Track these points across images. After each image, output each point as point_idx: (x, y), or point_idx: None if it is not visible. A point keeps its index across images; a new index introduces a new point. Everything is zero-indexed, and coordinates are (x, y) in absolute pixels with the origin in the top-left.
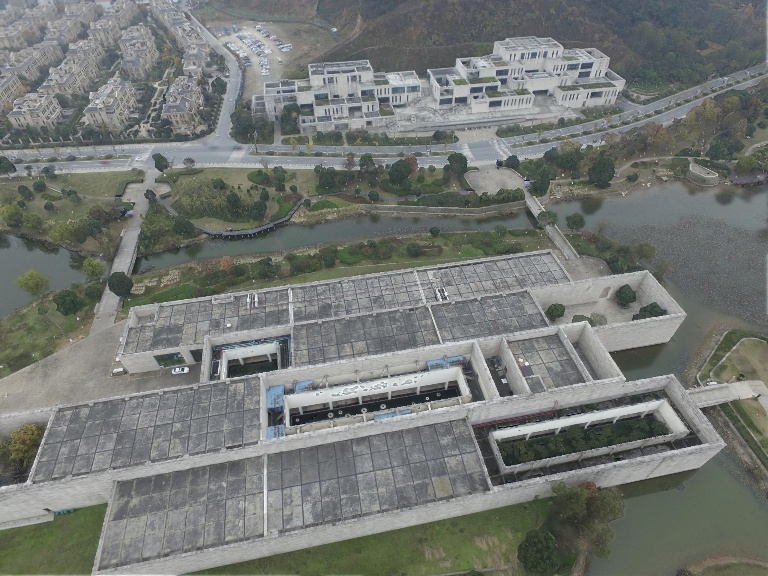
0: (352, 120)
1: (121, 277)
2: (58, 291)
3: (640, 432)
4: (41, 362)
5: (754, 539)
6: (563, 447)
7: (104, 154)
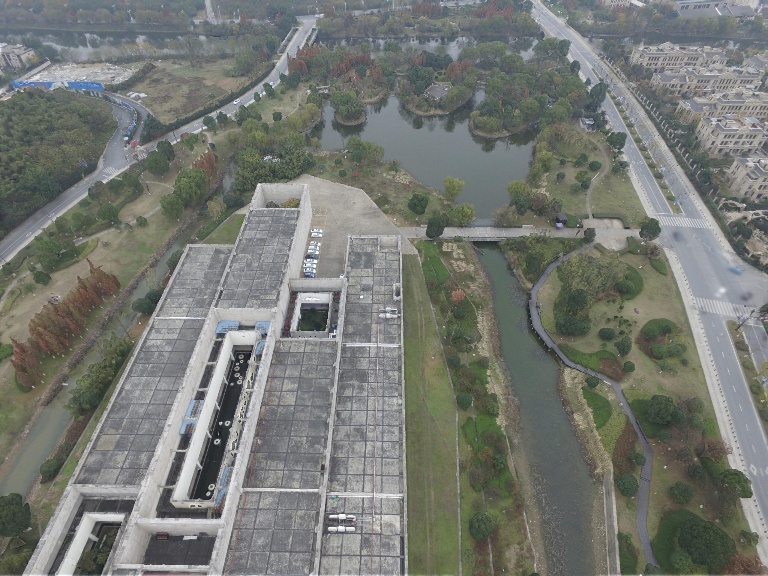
0: None
1: (434, 223)
2: (455, 205)
3: None
4: (378, 210)
5: None
6: None
7: (676, 194)
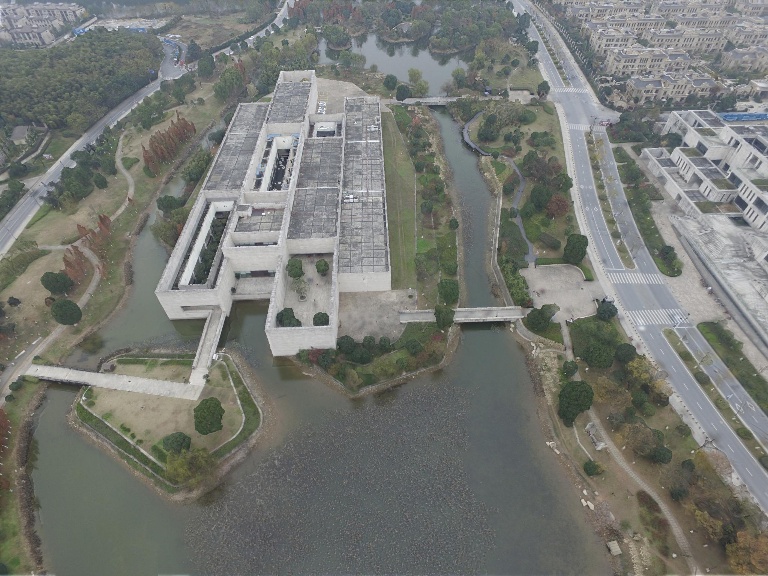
0: (672, 181)
1: (401, 87)
2: None
3: (200, 275)
4: (364, 92)
5: (118, 326)
6: (215, 238)
7: None
